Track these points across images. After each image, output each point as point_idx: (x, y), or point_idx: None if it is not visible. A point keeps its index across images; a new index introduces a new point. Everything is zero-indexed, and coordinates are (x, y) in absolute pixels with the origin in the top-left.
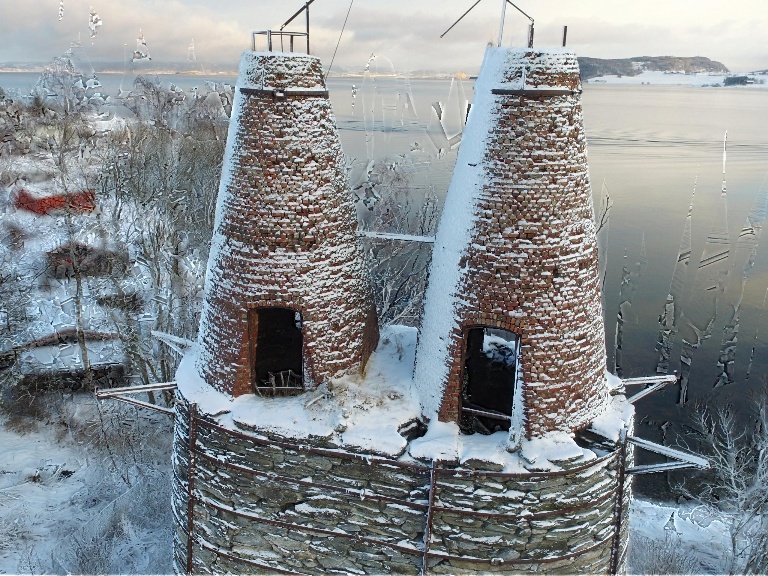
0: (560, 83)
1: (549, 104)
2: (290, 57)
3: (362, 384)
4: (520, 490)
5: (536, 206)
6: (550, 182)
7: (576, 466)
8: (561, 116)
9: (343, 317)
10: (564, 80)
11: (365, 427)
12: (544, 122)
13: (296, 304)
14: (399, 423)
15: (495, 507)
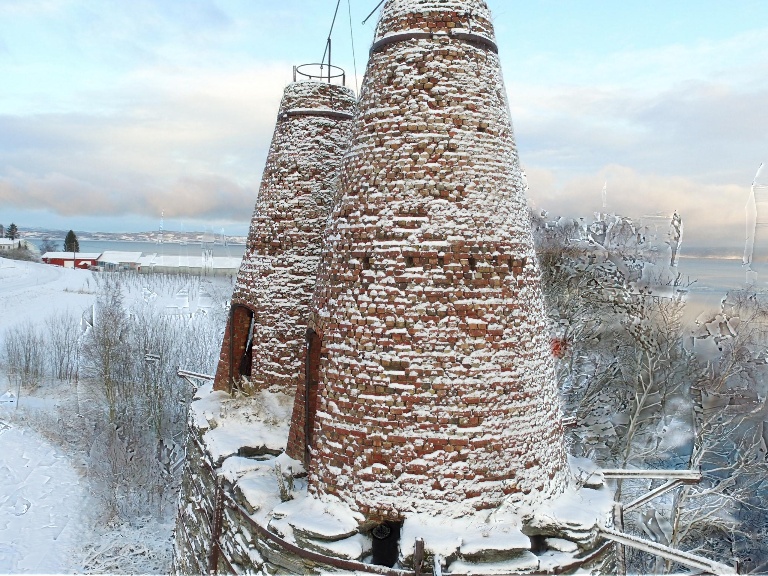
0: (409, 26)
1: (392, 53)
2: (299, 83)
3: (284, 404)
4: (262, 554)
5: (358, 175)
6: (377, 145)
7: (313, 549)
8: (404, 64)
9: (292, 329)
10: (417, 22)
11: (227, 431)
12: (383, 74)
13: (252, 304)
14: (261, 443)
15: (245, 568)
